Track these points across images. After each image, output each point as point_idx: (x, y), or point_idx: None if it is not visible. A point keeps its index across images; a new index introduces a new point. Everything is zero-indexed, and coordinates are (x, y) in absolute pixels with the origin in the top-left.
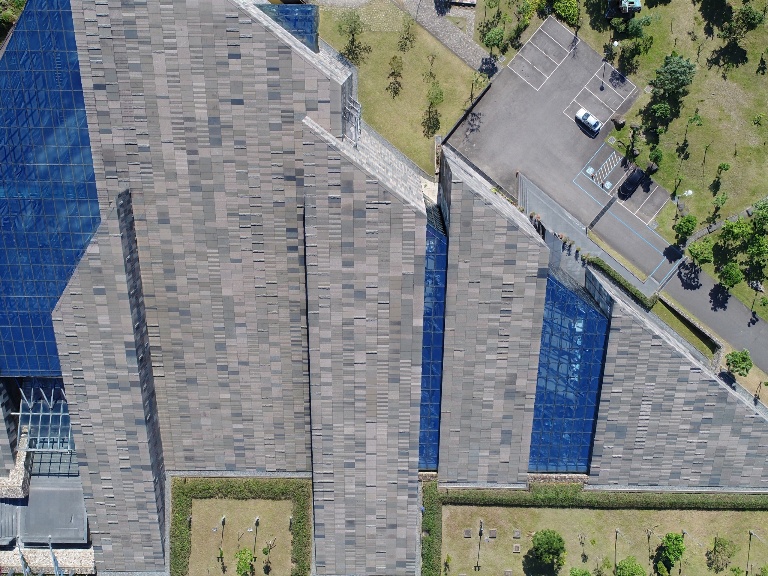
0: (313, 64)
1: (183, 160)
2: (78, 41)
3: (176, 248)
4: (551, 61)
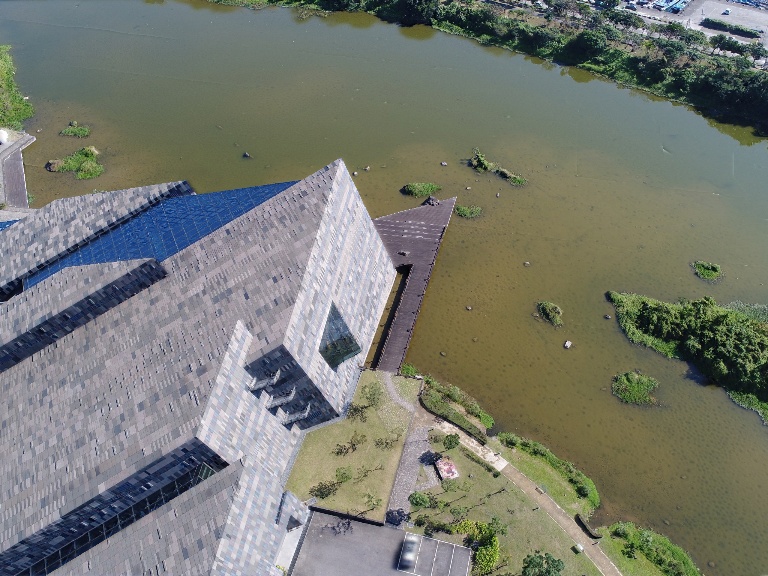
0: (290, 320)
1: (198, 290)
2: (251, 211)
3: (135, 318)
4: (431, 569)
